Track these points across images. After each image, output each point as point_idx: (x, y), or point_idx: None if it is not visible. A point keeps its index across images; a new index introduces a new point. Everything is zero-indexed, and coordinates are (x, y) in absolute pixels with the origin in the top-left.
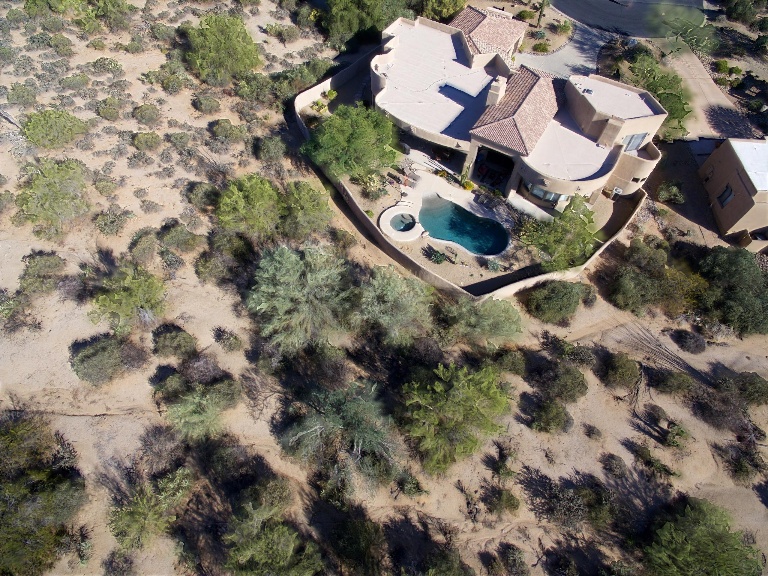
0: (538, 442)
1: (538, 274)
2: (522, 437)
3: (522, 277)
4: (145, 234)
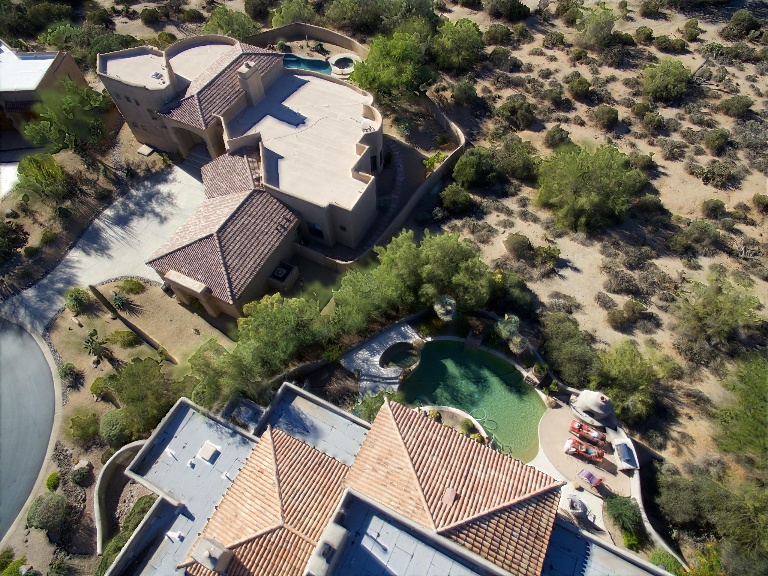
0: None
1: None
2: None
3: None
4: (526, 34)
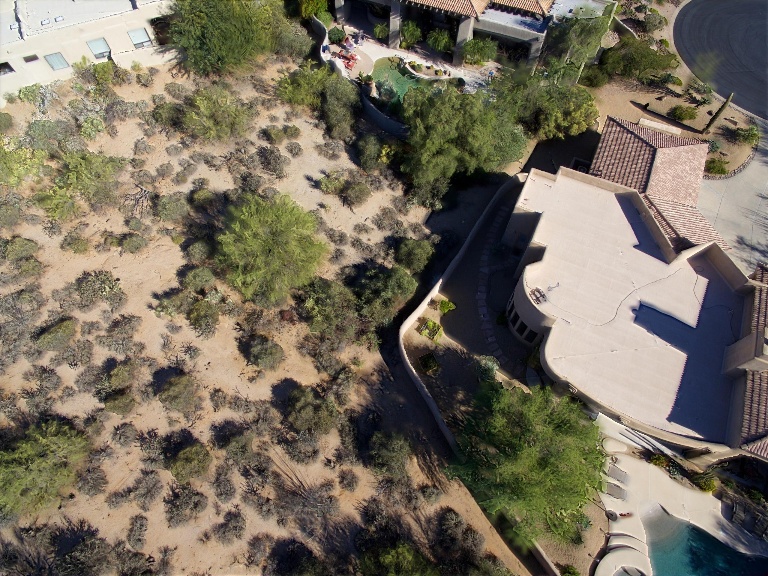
0: None
1: None
2: None
3: None
4: None
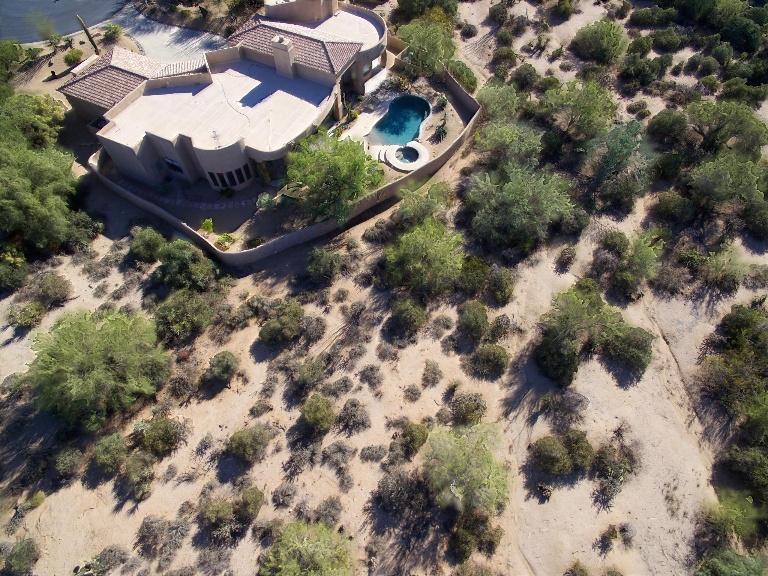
0: None
1: (438, 85)
2: None
3: (444, 92)
4: (479, 360)
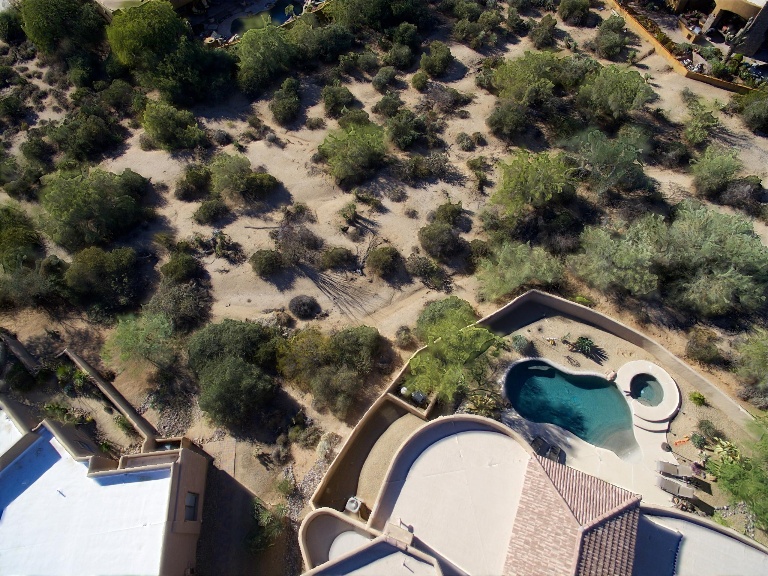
0: (455, 202)
1: None
2: (468, 202)
3: None
4: None
